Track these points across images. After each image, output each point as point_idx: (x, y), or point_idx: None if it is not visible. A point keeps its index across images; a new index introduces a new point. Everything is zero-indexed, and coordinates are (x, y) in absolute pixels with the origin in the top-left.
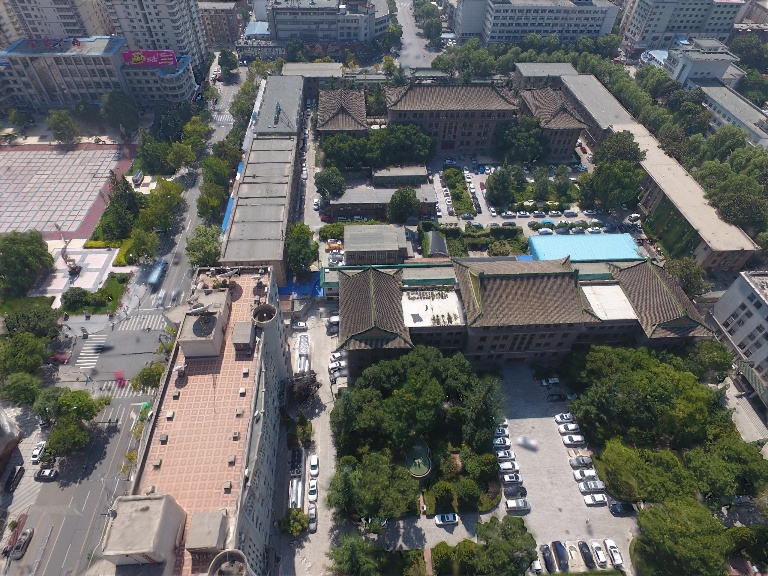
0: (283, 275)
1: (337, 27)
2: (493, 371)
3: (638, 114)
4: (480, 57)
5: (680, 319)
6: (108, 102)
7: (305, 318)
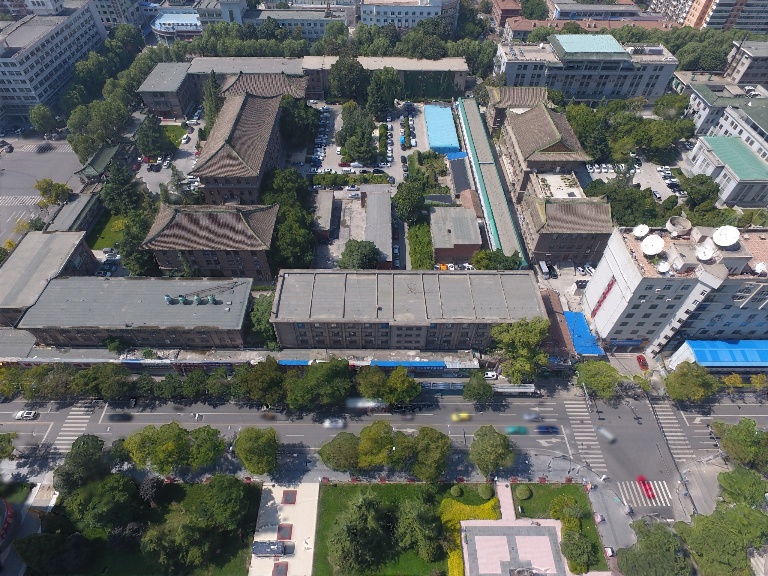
0: None
1: None
2: None
3: None
4: (113, 107)
5: None
6: None
7: None
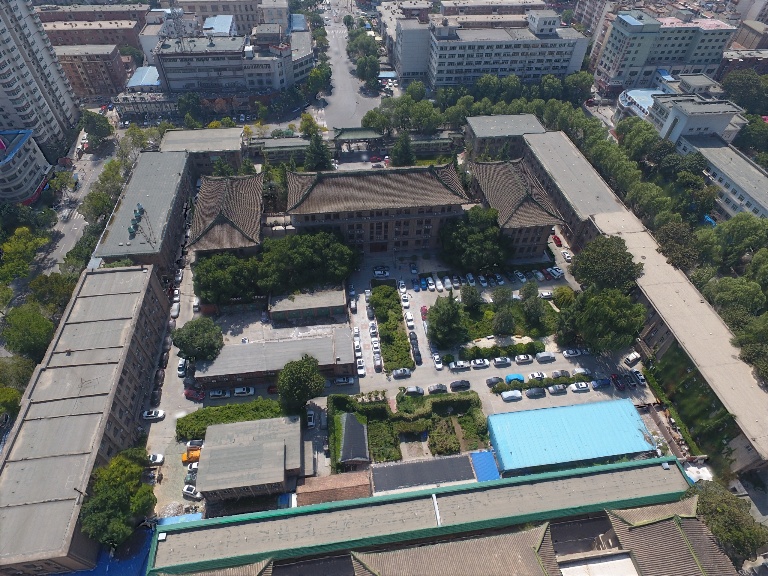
0: (83, 561)
1: (244, 74)
2: None
3: (624, 189)
4: (422, 112)
5: None
6: None
7: None
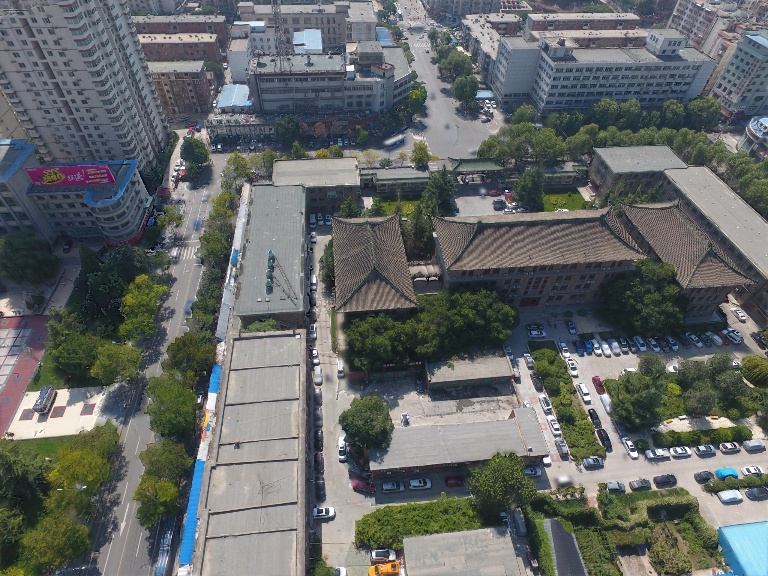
0: None
1: (343, 95)
2: None
3: None
4: (547, 142)
5: None
6: (3, 254)
7: None
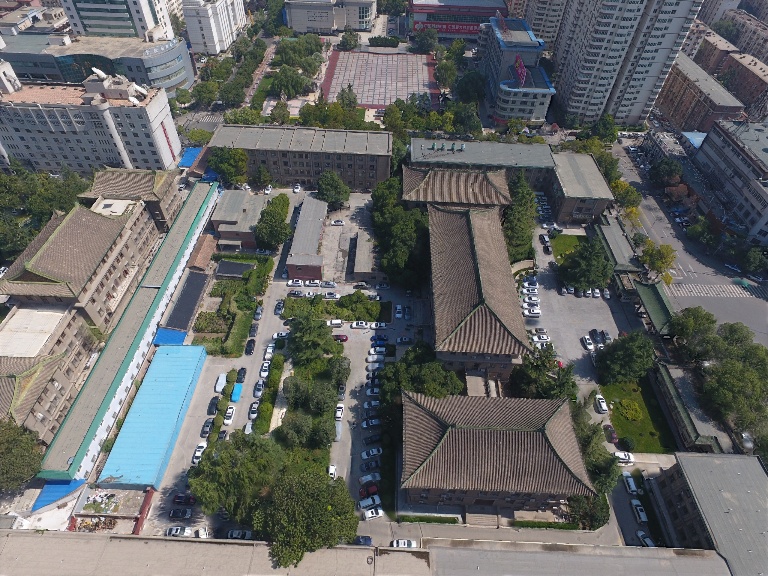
0: None
1: None
2: None
3: None
4: (728, 375)
5: None
6: None
7: None
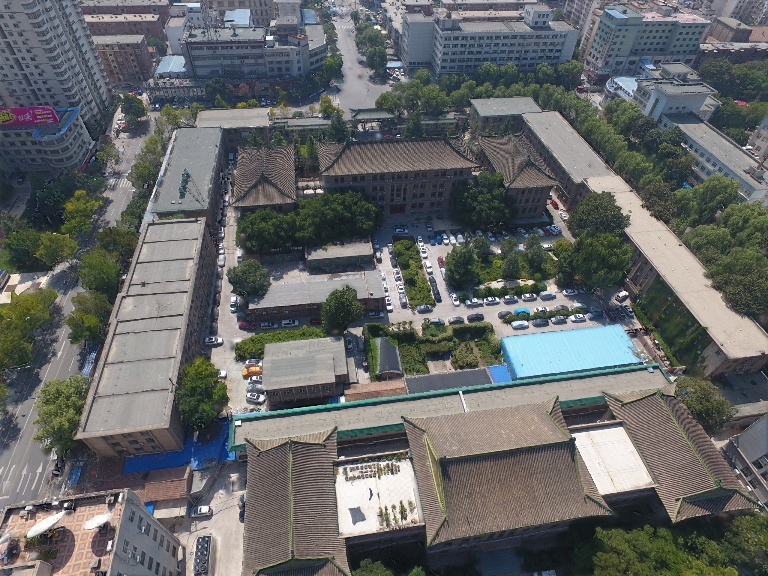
0: (175, 439)
1: (265, 61)
2: (467, 568)
3: (612, 159)
4: (430, 94)
5: (712, 491)
6: None
7: (210, 495)
